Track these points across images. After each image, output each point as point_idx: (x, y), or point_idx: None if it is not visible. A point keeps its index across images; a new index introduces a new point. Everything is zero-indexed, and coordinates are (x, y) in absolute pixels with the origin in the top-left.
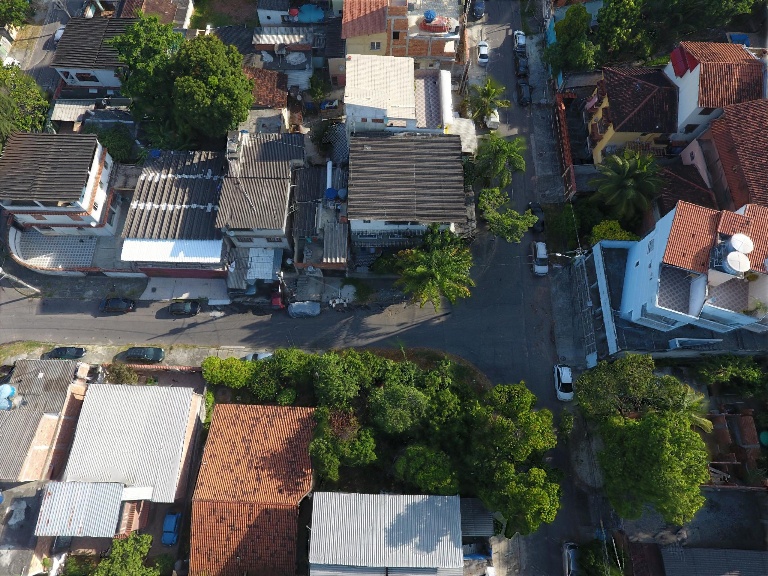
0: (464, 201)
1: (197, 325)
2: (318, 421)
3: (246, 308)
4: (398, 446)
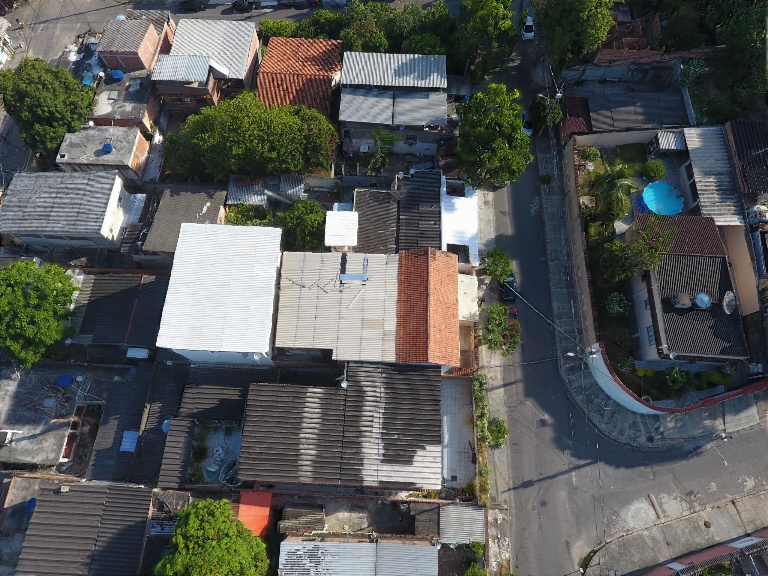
0: None
1: (252, 17)
2: None
3: (290, 6)
4: None
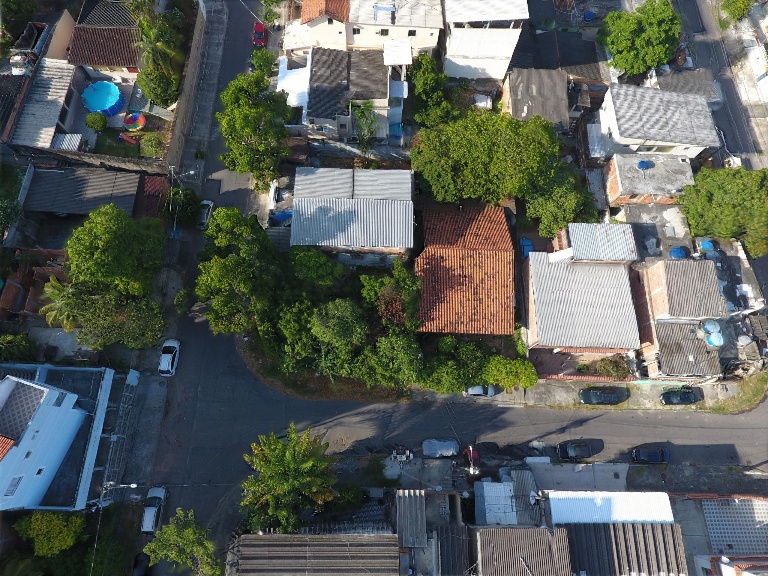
0: (240, 572)
1: (555, 431)
2: (415, 316)
3: (506, 452)
4: (340, 292)
